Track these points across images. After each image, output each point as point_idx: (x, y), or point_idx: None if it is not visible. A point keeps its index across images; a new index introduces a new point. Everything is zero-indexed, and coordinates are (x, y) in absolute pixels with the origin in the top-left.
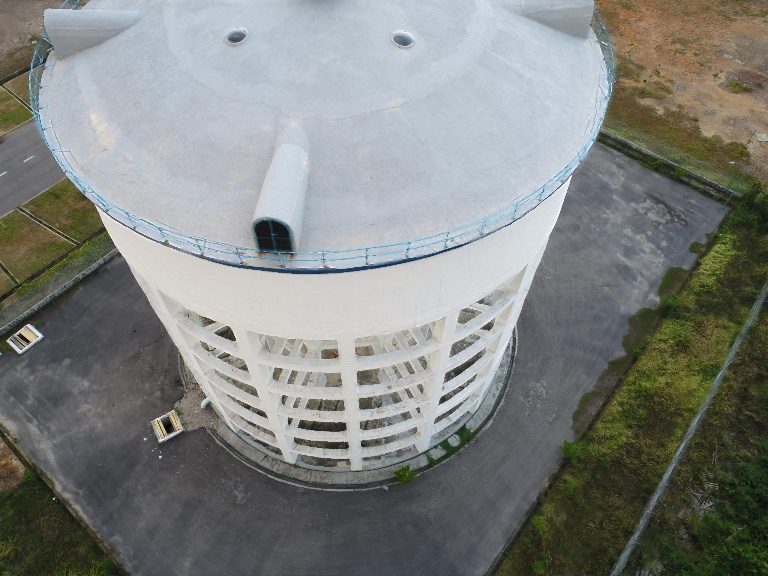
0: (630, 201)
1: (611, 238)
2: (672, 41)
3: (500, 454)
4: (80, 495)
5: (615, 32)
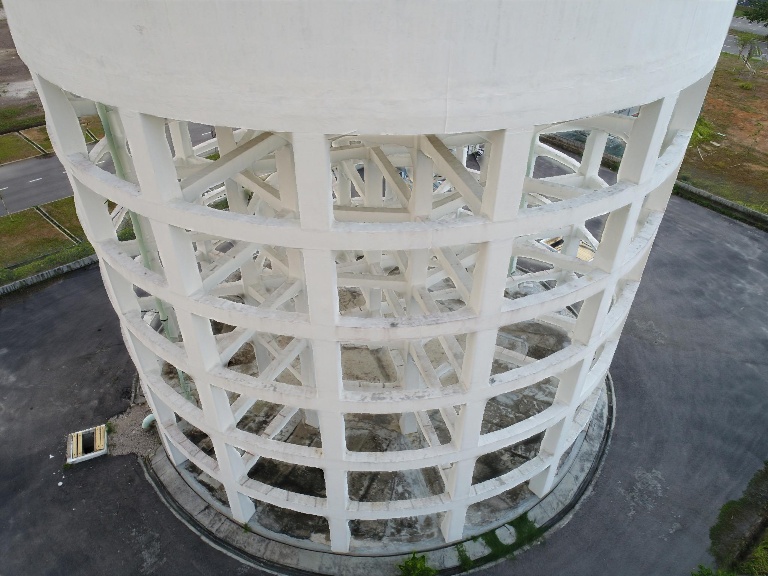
0: None
1: (751, 309)
2: None
3: (583, 571)
4: None
5: (733, 127)
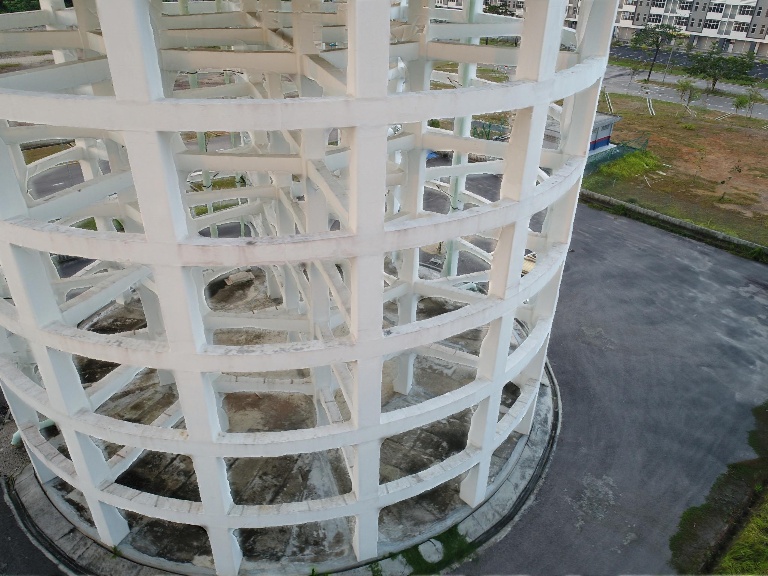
0: (725, 284)
1: (704, 316)
2: (748, 169)
3: None
4: None
5: (678, 159)
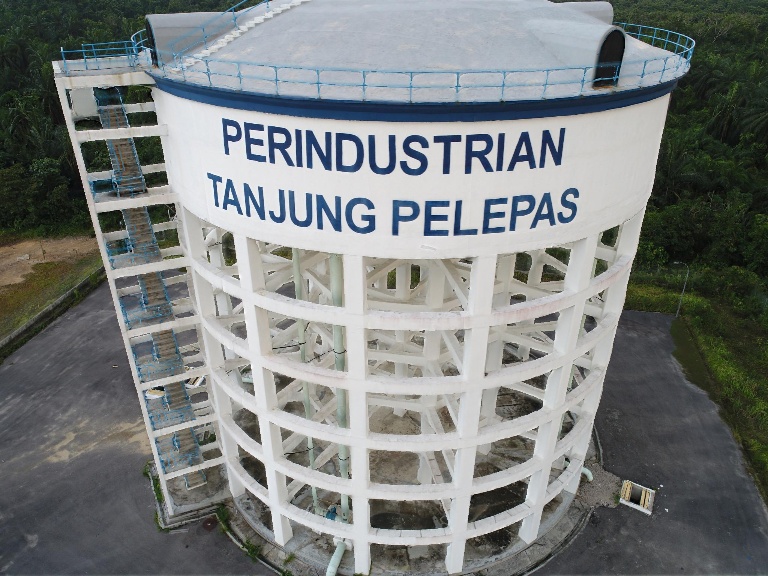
0: (136, 303)
1: None
2: None
3: None
4: (764, 529)
5: None
